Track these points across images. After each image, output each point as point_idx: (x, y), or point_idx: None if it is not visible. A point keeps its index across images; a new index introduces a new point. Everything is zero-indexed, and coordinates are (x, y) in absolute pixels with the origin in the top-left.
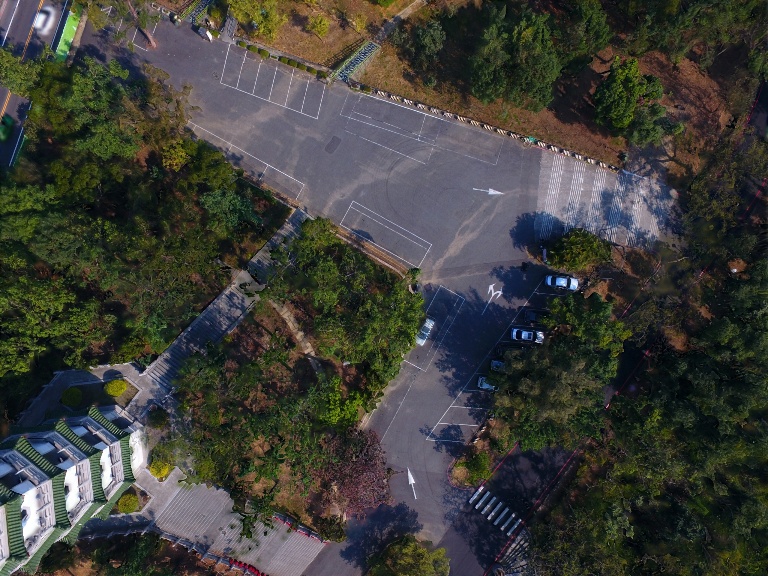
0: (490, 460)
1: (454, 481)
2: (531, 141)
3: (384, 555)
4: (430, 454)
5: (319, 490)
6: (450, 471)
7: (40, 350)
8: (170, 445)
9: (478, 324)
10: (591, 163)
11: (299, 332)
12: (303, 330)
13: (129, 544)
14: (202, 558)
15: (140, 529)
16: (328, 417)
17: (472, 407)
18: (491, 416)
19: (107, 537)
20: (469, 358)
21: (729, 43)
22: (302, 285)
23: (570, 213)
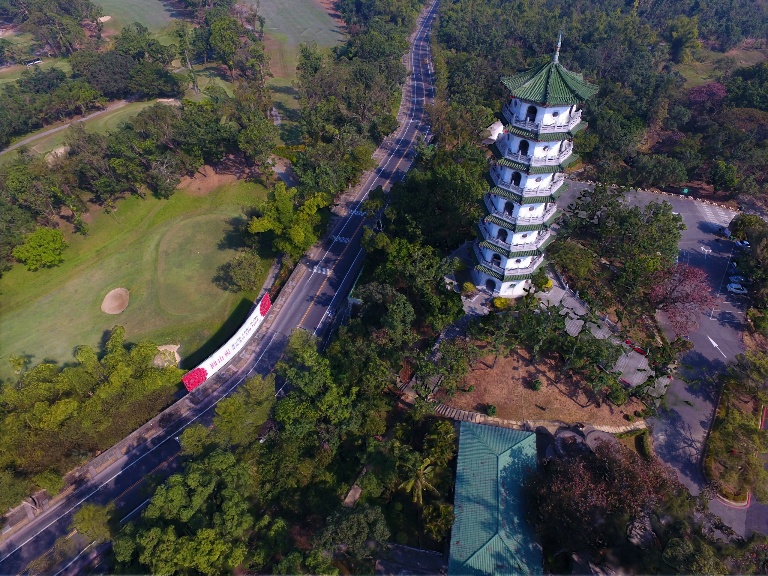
0: (767, 342)
1: (749, 349)
2: (684, 196)
3: None
4: (719, 328)
5: (647, 340)
6: (741, 340)
7: None
8: (562, 252)
9: (706, 263)
10: (724, 207)
11: (594, 254)
12: (596, 253)
13: None
14: None
15: None
16: (649, 261)
17: (732, 302)
18: (750, 307)
19: None
20: (712, 278)
21: (763, 181)
22: (584, 238)
23: (727, 224)
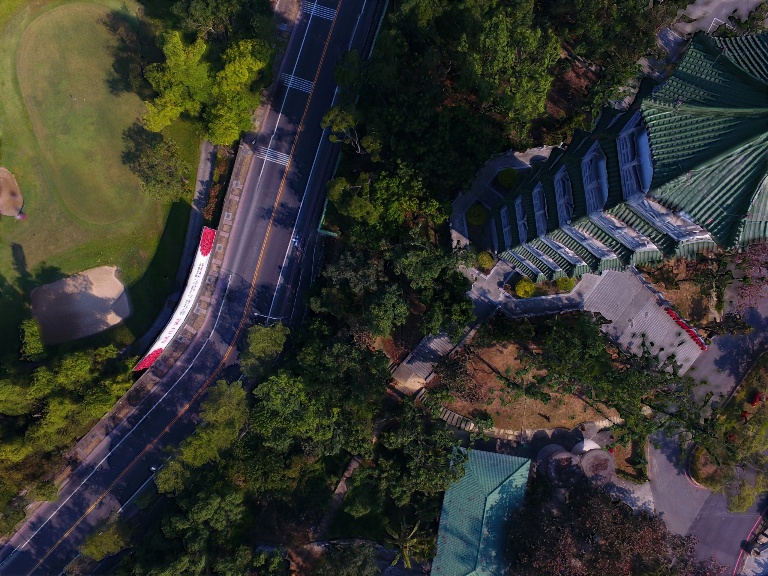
0: None
1: None
2: None
3: (760, 363)
4: None
5: (699, 296)
6: None
7: (542, 98)
8: None
9: None
10: None
11: None
12: None
13: (566, 321)
14: (622, 344)
15: (574, 308)
16: None
17: None
18: None
19: (548, 313)
20: None
21: None
22: None
23: None
